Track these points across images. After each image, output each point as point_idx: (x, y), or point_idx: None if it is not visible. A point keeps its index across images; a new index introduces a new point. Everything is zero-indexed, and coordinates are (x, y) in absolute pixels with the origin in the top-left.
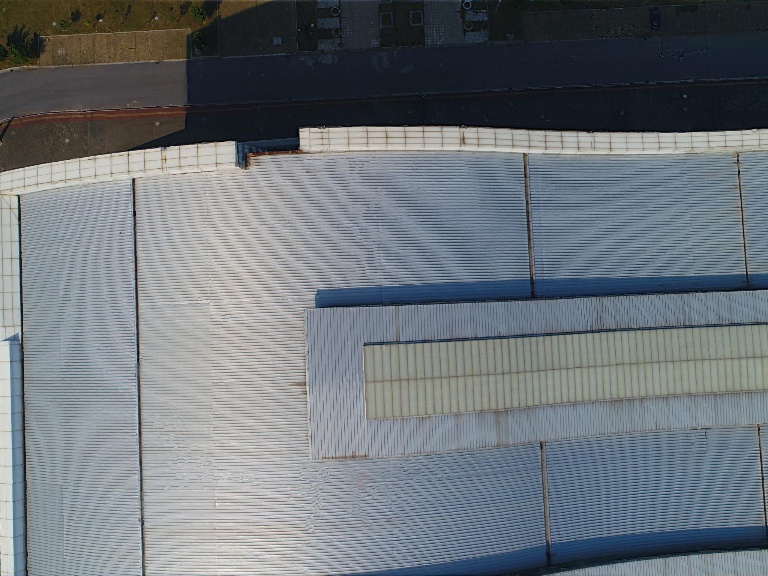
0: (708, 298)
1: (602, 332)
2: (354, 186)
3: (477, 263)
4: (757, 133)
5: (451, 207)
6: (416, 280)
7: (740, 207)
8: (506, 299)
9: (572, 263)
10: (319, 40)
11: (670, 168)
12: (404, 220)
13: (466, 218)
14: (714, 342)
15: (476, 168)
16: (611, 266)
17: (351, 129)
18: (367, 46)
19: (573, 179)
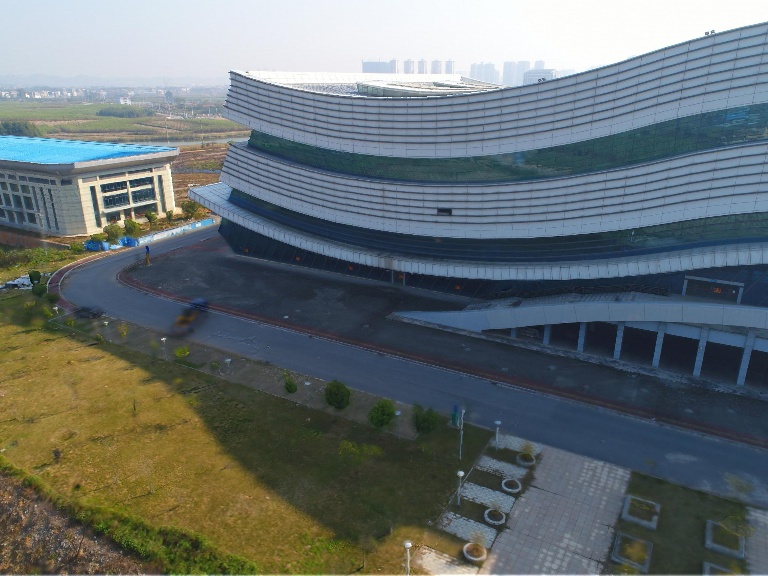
0: None
1: None
2: None
3: None
4: None
5: None
6: None
7: None
8: None
9: None
10: None
11: None
12: None
13: None
14: None
15: None
16: None
17: None
18: None
19: None
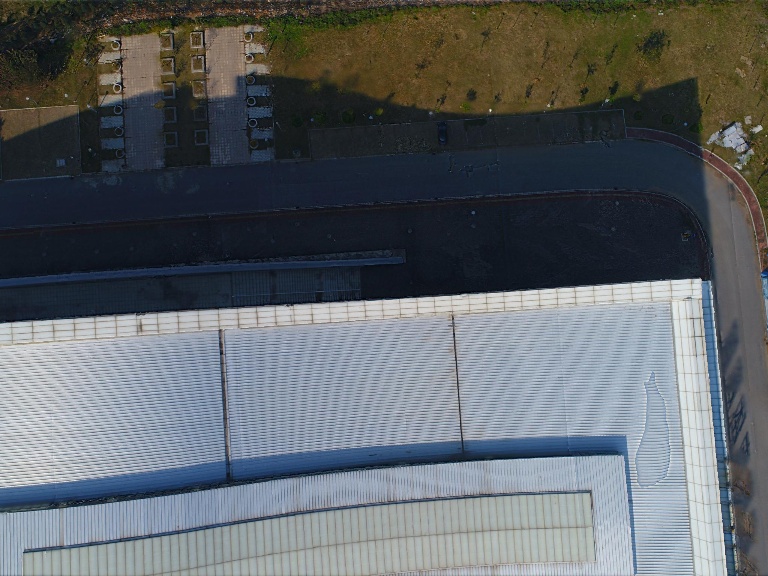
0: (414, 472)
1: (297, 515)
2: (24, 380)
3: (162, 451)
4: (467, 298)
5: (132, 395)
6: (92, 474)
7: (455, 371)
8: (195, 485)
9: (274, 439)
10: (103, 161)
11: (382, 333)
12: (79, 412)
13: (150, 405)
14: (419, 518)
15: (162, 351)
16: (318, 439)
17: (15, 324)
18: (152, 167)
19: (276, 352)
